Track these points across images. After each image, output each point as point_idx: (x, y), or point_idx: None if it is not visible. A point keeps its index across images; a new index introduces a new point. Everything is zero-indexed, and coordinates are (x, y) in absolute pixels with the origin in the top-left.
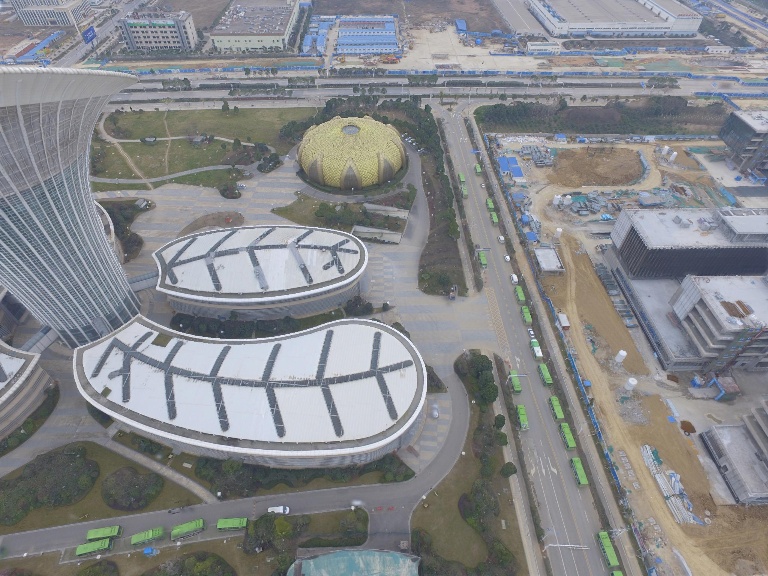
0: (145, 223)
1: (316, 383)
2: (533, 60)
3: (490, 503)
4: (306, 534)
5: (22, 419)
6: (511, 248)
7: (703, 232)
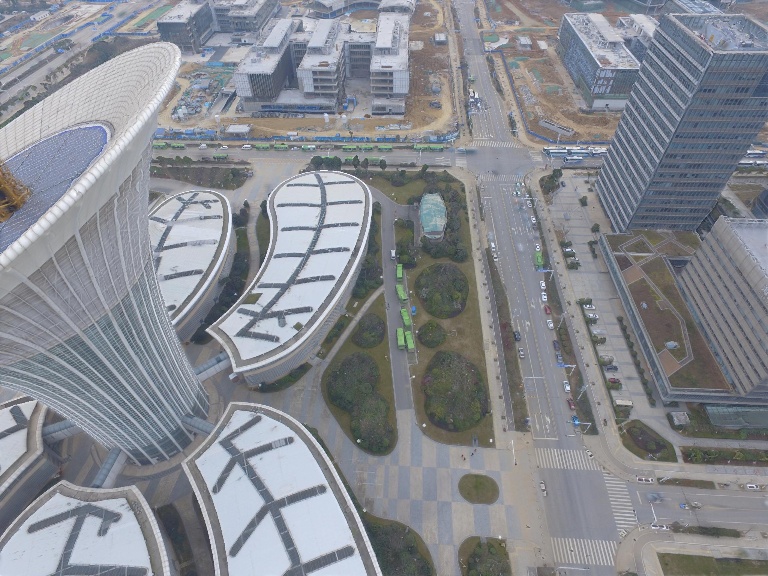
0: None
1: None
2: None
3: (398, 175)
4: None
5: None
6: (215, 145)
7: (267, 58)
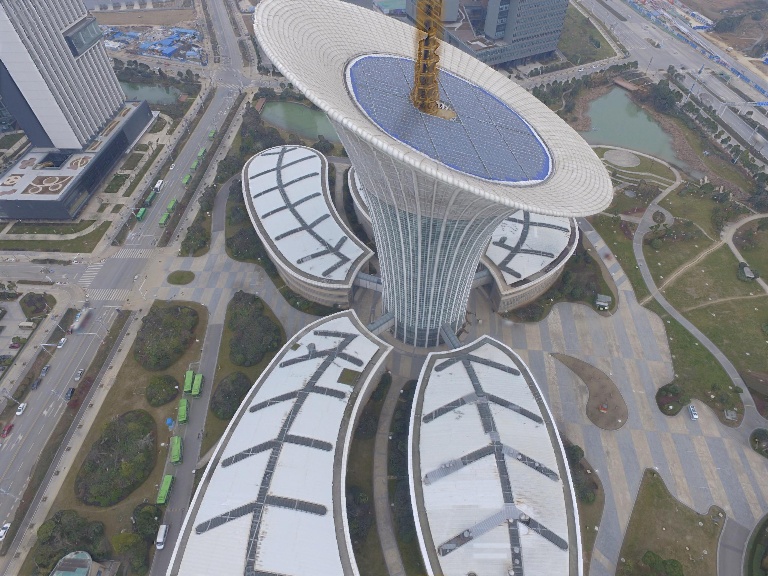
0: (572, 314)
1: (250, 571)
2: None
3: None
4: (129, 571)
5: (313, 299)
6: None
7: None
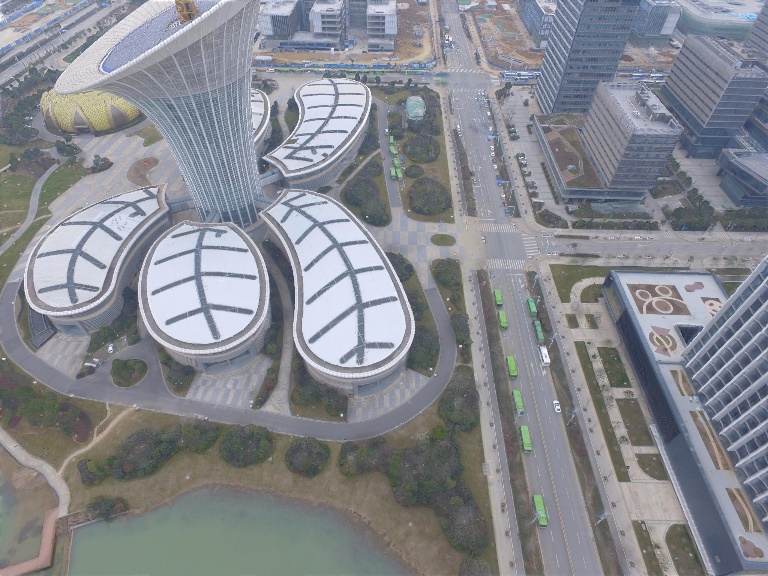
0: None
1: None
2: (2, 32)
3: (389, 87)
4: None
5: None
6: None
7: (284, 5)
